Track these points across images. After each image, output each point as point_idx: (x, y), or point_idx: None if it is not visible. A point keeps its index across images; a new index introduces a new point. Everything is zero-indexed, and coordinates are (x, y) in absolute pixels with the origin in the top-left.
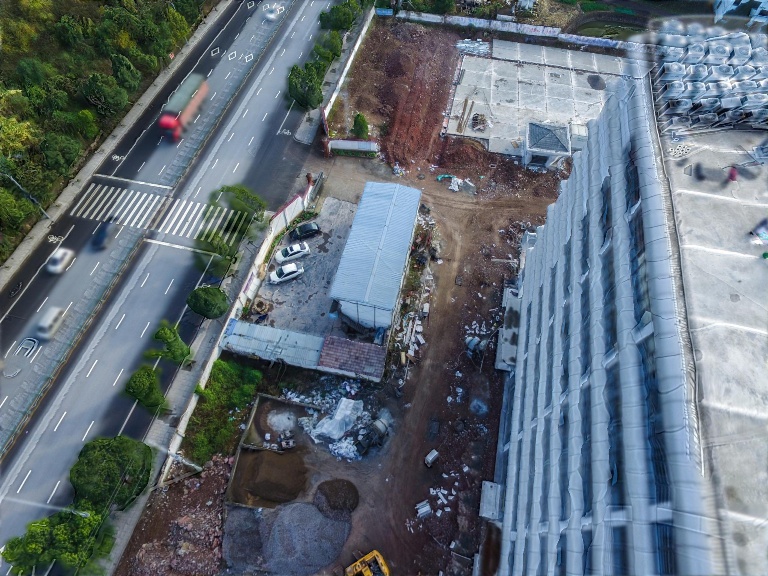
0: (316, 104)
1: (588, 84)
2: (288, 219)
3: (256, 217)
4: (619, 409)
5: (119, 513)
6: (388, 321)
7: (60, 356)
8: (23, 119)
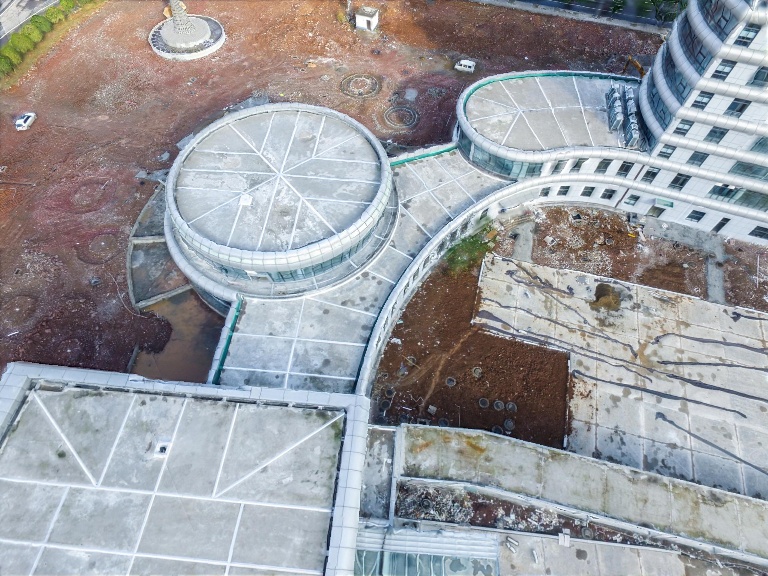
0: None
1: None
2: None
3: None
4: None
5: (648, 25)
6: None
7: None
8: None
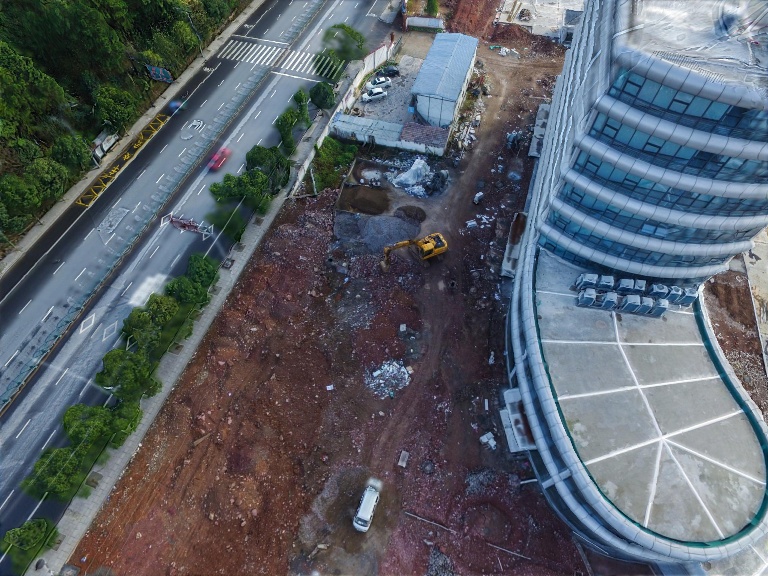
0: None
1: None
2: (376, 63)
3: (358, 45)
4: (600, 21)
5: (266, 206)
6: (450, 117)
7: (219, 130)
8: None
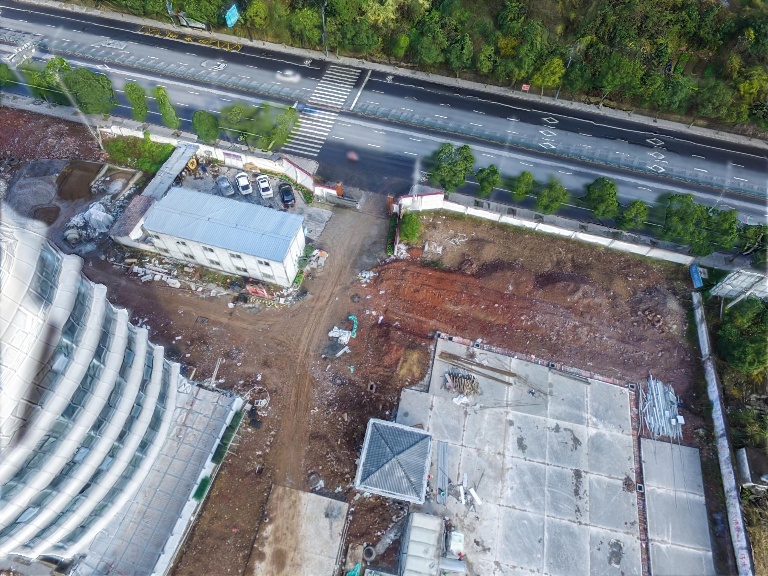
0: (442, 185)
1: None
2: None
3: None
4: None
5: None
6: None
7: (207, 79)
8: (408, 18)
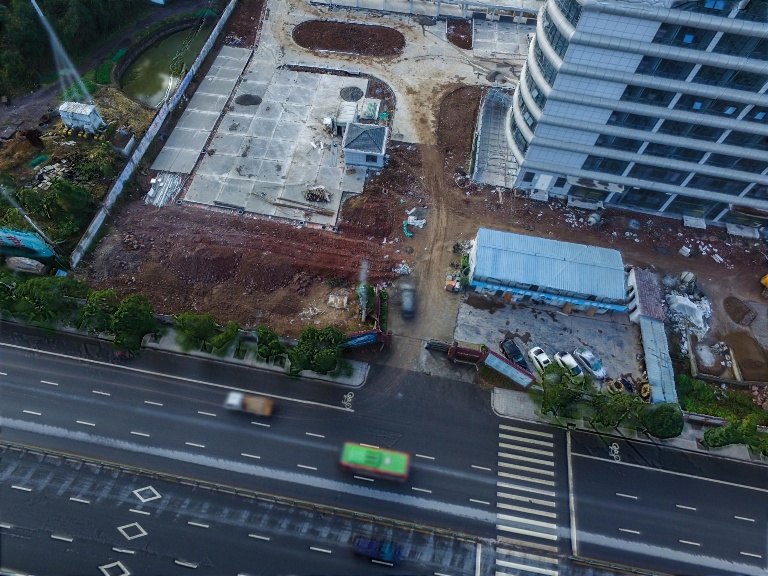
0: None
1: (251, 106)
2: None
3: None
4: None
5: None
6: None
7: None
8: None
